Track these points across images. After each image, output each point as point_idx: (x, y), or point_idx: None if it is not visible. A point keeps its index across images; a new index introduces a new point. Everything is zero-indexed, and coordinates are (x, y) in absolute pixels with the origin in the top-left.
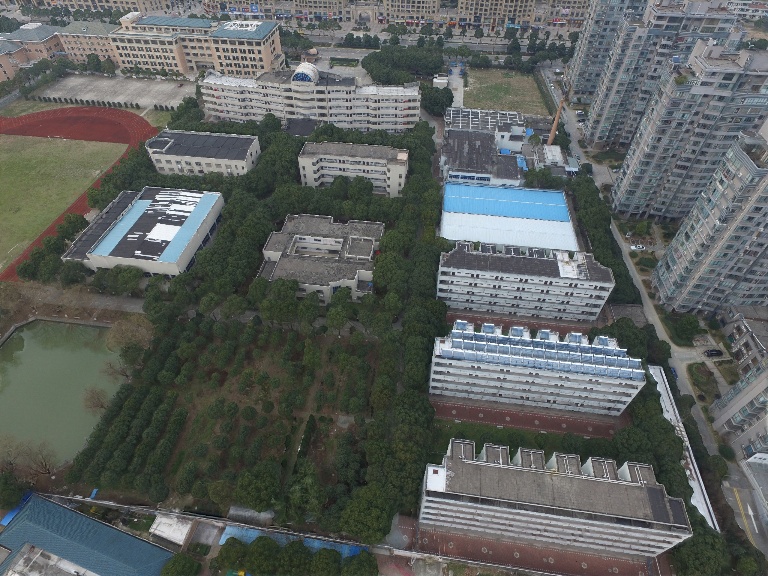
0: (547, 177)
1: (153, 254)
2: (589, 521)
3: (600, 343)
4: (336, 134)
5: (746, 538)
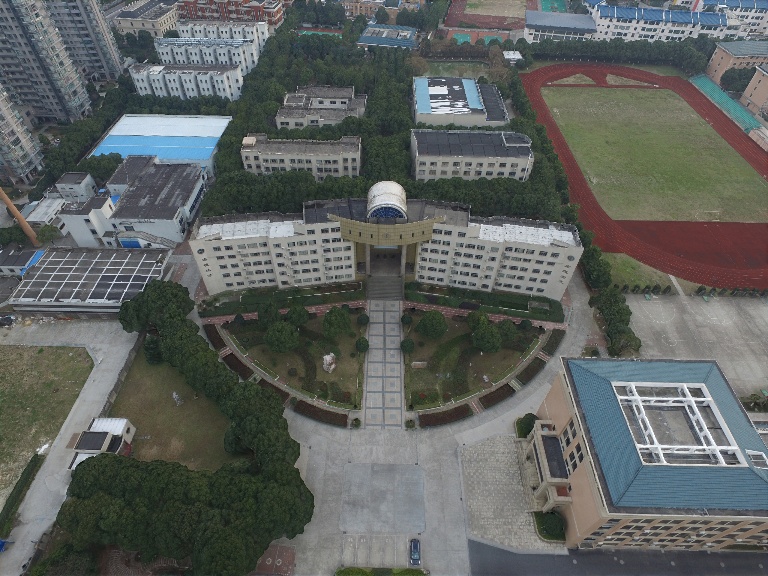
0: (97, 156)
1: (433, 80)
2: (212, 20)
3: (168, 45)
4: (329, 182)
5: (150, 48)
